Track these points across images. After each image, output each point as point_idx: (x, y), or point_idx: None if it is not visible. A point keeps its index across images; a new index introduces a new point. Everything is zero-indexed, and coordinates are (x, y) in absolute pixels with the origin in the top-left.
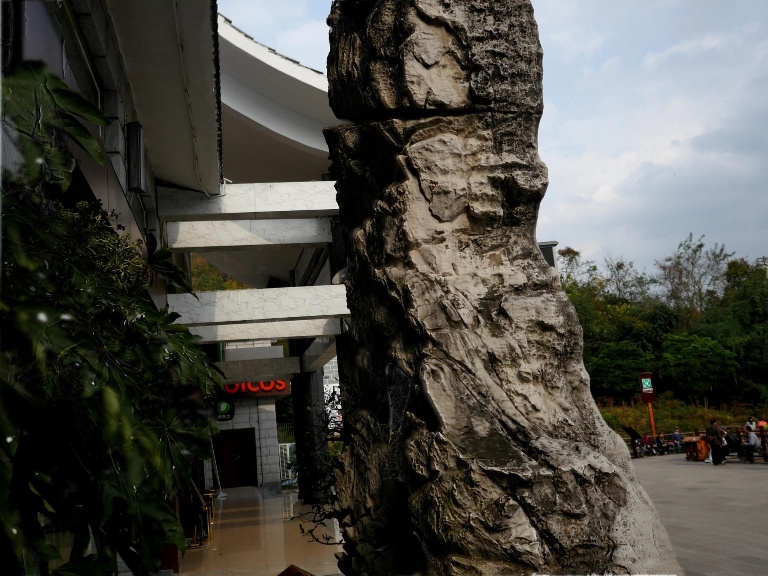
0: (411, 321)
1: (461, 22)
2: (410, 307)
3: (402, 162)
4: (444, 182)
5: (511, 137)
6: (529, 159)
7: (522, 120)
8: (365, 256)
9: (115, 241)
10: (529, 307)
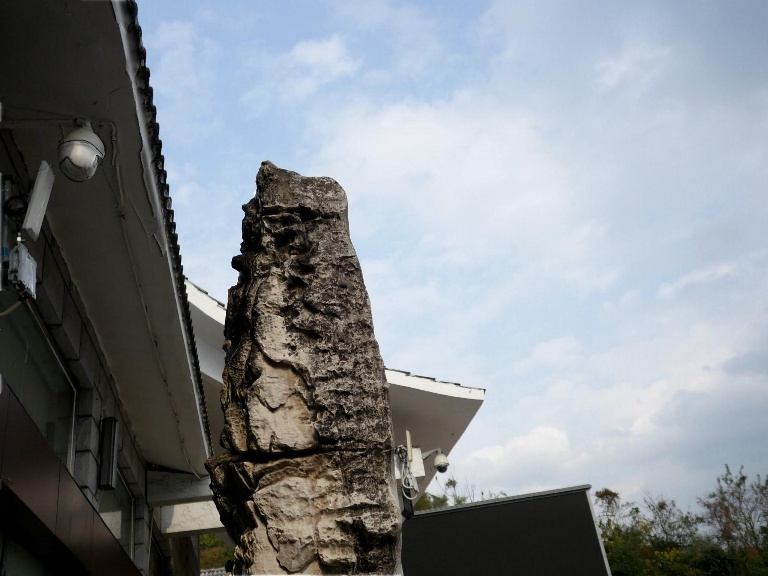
0: None
1: (305, 364)
2: None
3: (250, 508)
4: (289, 530)
5: (362, 475)
6: (380, 498)
7: (373, 456)
8: None
9: None
10: None
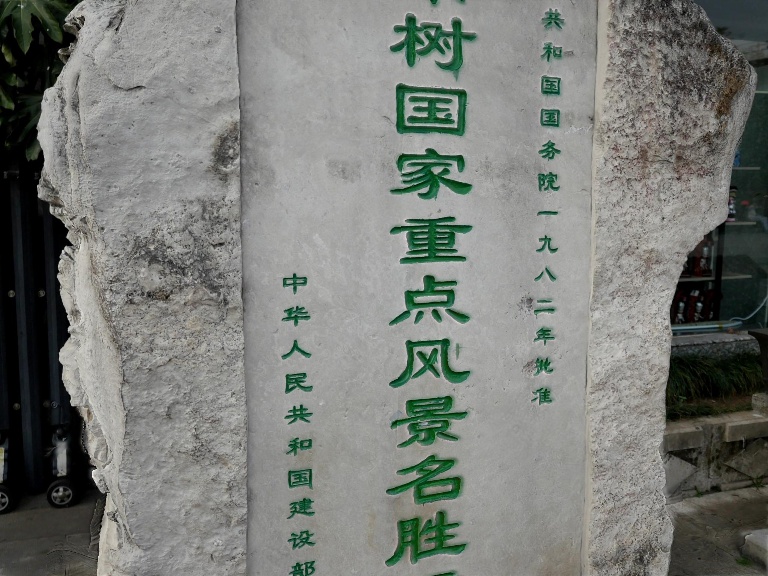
0: None
1: None
2: None
3: None
4: None
5: None
6: None
7: None
8: None
9: None
10: None
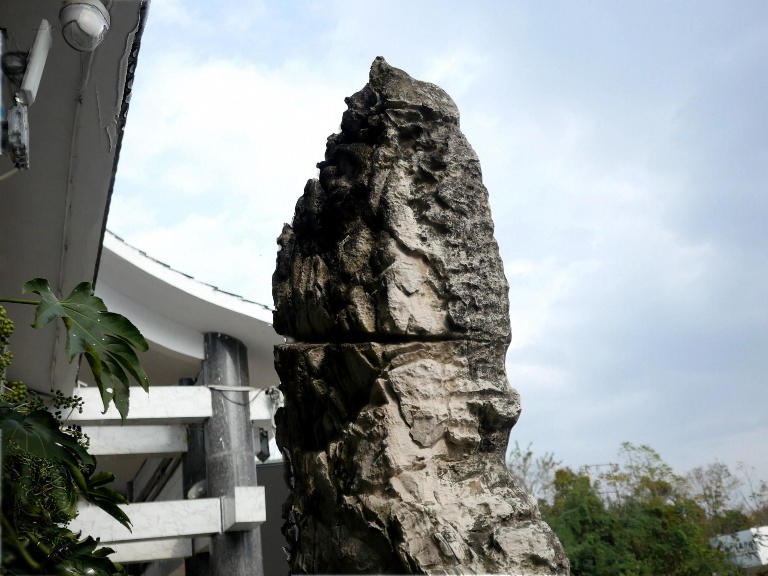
0: (401, 556)
1: (439, 255)
2: (400, 541)
3: (381, 385)
4: (426, 407)
5: (485, 364)
6: (503, 386)
7: (494, 348)
8: (327, 480)
9: (38, 459)
10: (523, 540)
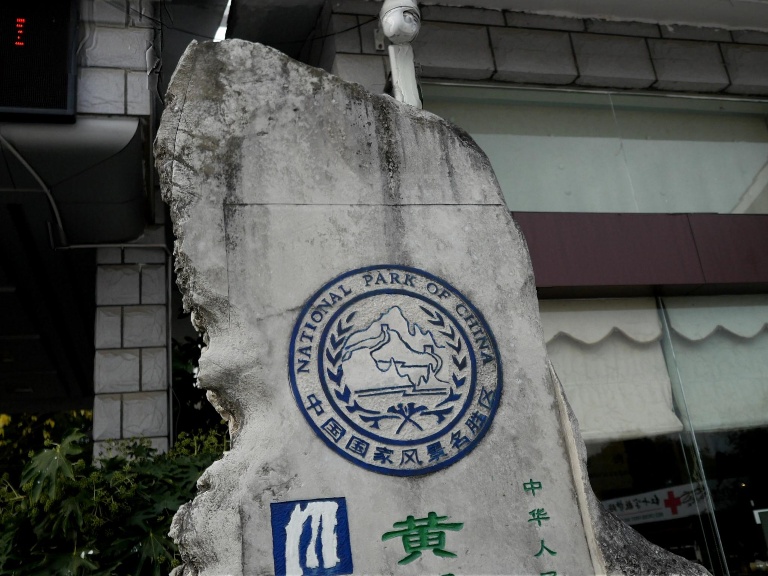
0: None
1: None
2: None
3: None
4: None
5: None
6: None
7: (203, 315)
8: None
9: None
10: None
